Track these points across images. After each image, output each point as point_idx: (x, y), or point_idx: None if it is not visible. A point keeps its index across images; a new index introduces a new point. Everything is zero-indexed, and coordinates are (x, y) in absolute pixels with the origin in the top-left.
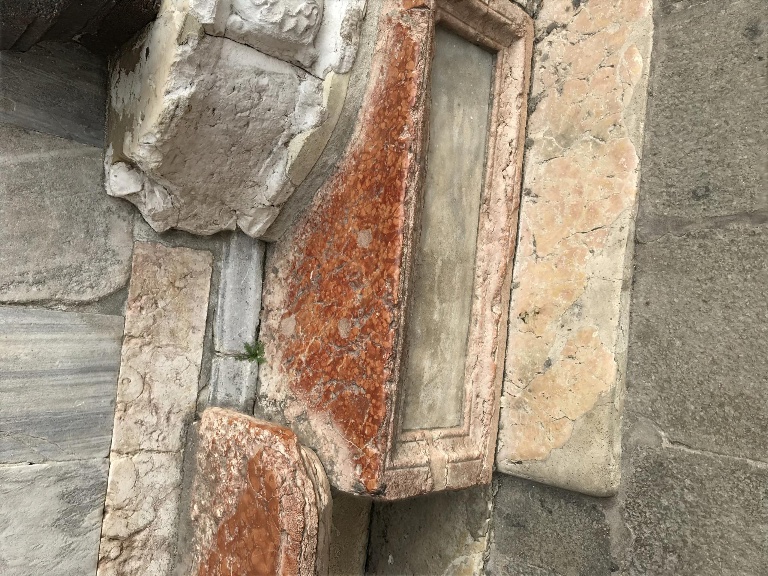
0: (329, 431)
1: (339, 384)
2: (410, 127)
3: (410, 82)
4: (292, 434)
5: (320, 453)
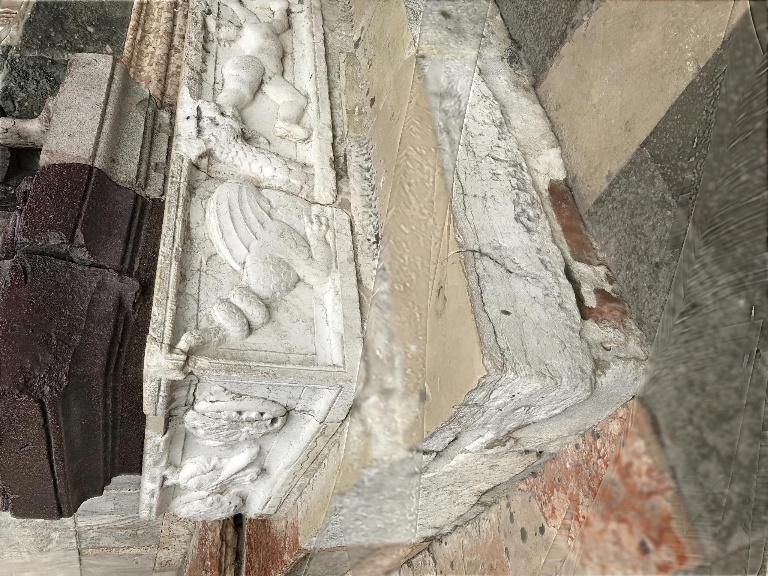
0: (244, 569)
1: (248, 568)
2: (274, 575)
3: (278, 567)
4: (216, 575)
5: (242, 567)
